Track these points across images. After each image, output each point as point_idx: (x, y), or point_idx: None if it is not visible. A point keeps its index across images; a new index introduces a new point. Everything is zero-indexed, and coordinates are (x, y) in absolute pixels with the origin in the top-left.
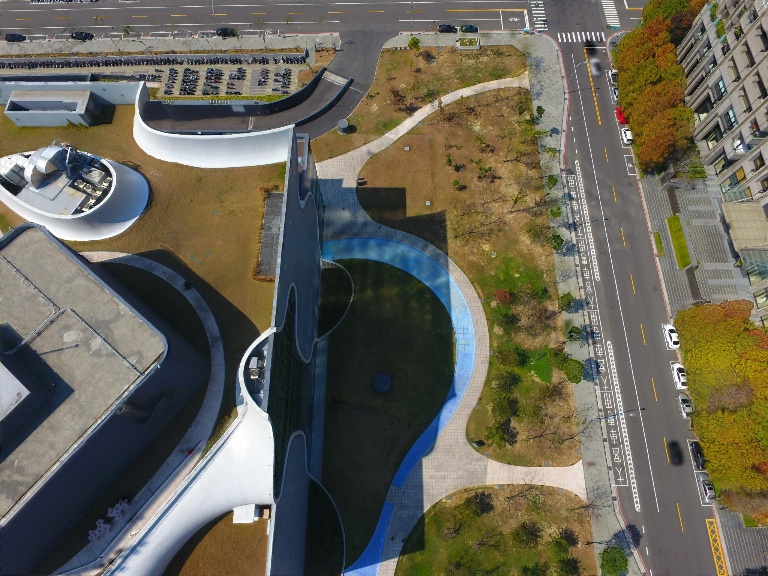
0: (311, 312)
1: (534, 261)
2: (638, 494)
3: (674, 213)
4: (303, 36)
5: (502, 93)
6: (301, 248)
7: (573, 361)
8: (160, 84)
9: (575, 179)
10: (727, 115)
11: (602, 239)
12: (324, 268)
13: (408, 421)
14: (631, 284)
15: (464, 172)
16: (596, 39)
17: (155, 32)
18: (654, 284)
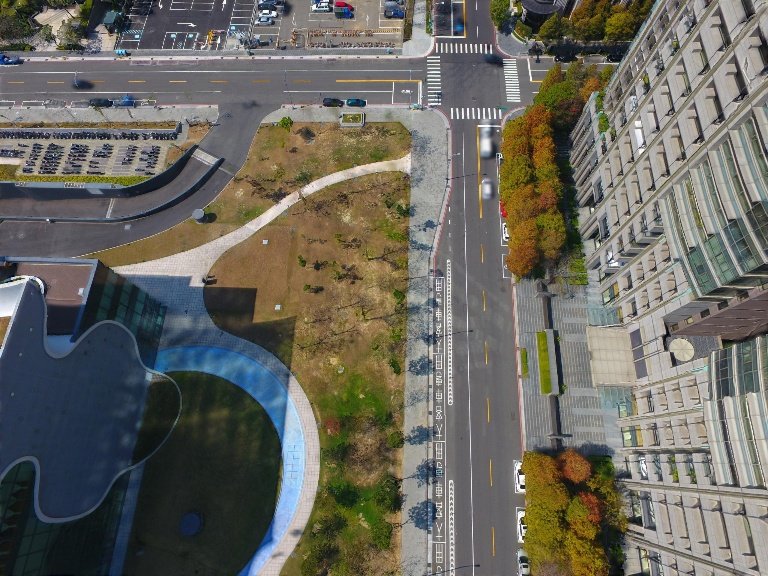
0: (106, 450)
1: (383, 379)
2: None
3: (545, 327)
4: (180, 108)
5: (380, 178)
6: (62, 400)
7: (381, 523)
8: (22, 161)
9: (443, 282)
10: (606, 221)
11: (462, 355)
12: (154, 381)
13: (214, 569)
14: (486, 411)
15: (324, 271)
16: (492, 116)
17: (28, 101)
18: (512, 411)
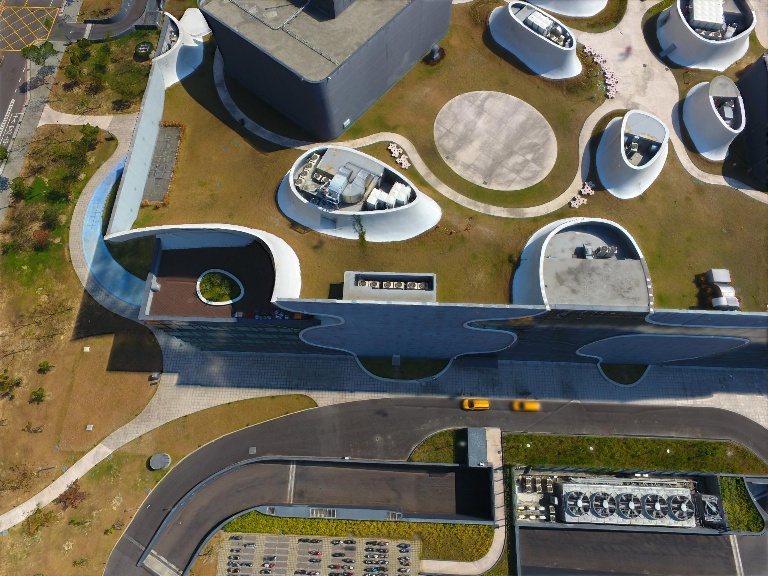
0: None
1: (2, 281)
2: (8, 108)
3: None
4: None
5: None
6: None
7: None
8: (420, 568)
9: None
10: None
11: None
12: None
13: None
14: None
15: None
16: None
17: None
18: None
